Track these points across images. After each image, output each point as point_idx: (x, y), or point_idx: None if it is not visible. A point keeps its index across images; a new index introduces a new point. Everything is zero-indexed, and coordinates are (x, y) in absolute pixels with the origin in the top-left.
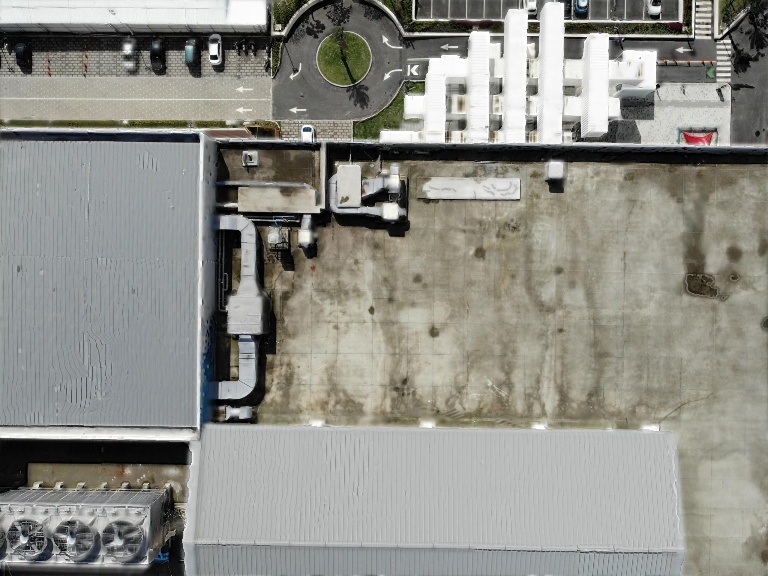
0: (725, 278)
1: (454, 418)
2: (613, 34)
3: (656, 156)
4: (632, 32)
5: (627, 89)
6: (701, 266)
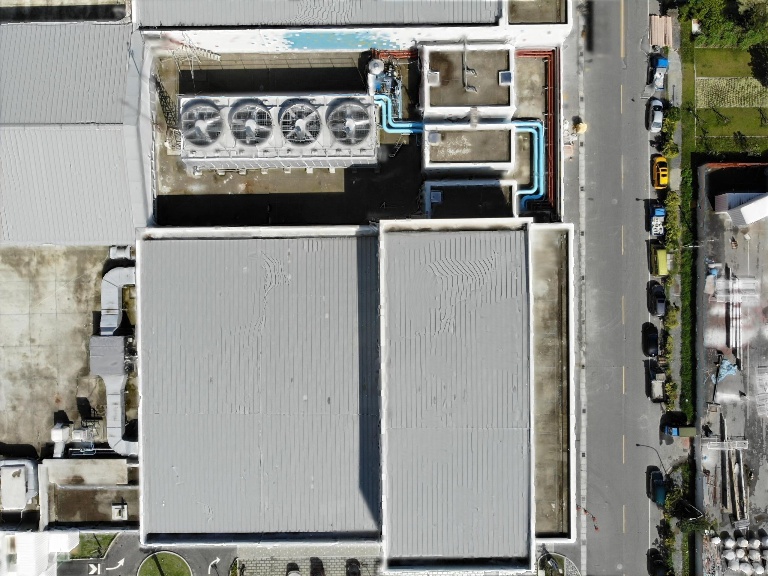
0: None
1: None
2: None
3: None
4: None
5: None
6: None
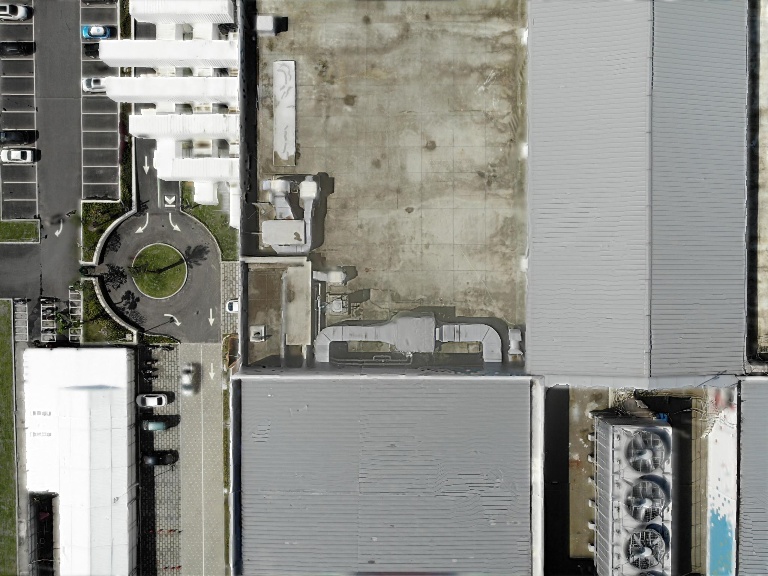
0: None
1: (518, 124)
2: None
3: None
4: None
5: None
6: None
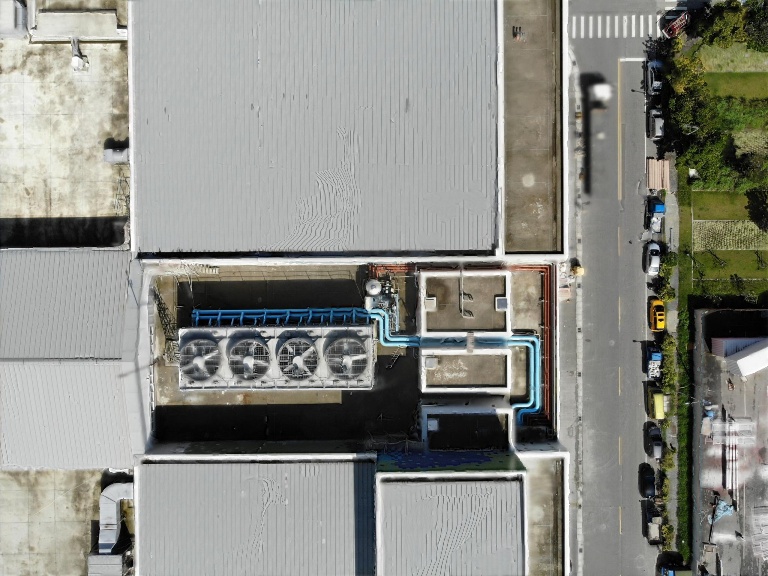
0: None
1: None
2: None
3: None
4: None
5: None
6: None
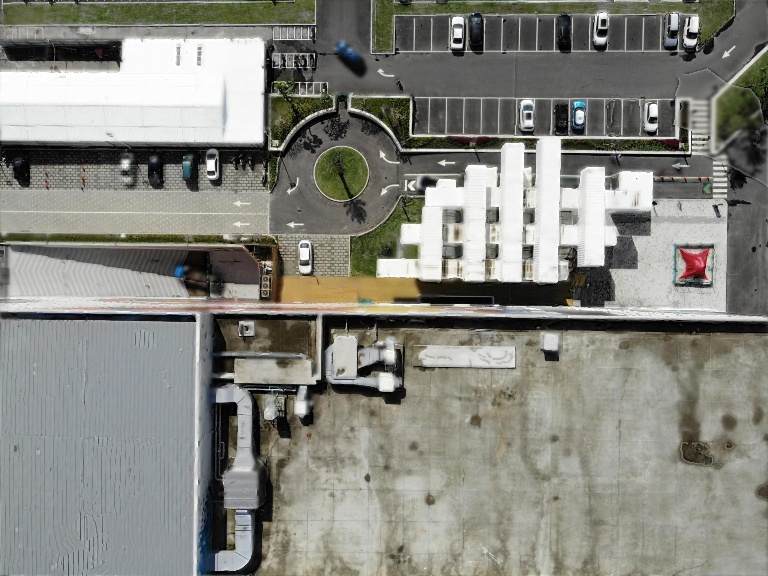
0: (720, 446)
1: None
2: (610, 151)
3: (651, 325)
4: (629, 149)
5: (624, 210)
6: (696, 434)
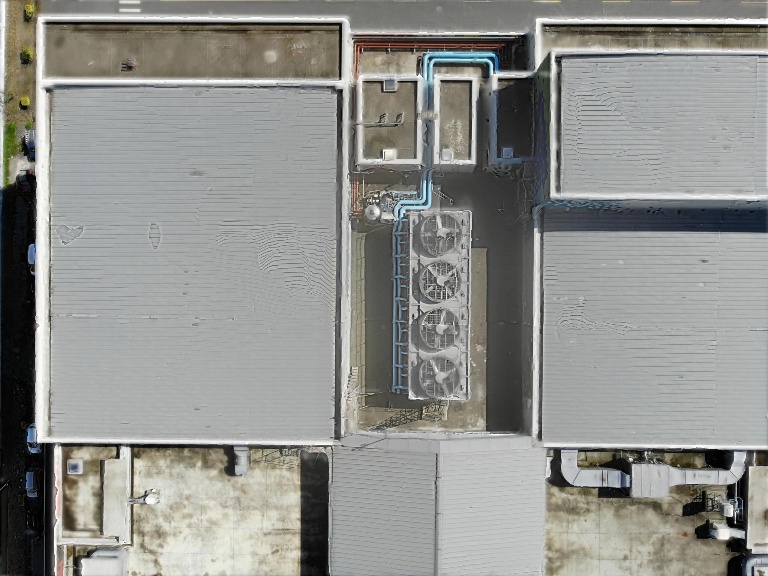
0: None
1: None
2: None
3: None
4: None
5: None
6: None
